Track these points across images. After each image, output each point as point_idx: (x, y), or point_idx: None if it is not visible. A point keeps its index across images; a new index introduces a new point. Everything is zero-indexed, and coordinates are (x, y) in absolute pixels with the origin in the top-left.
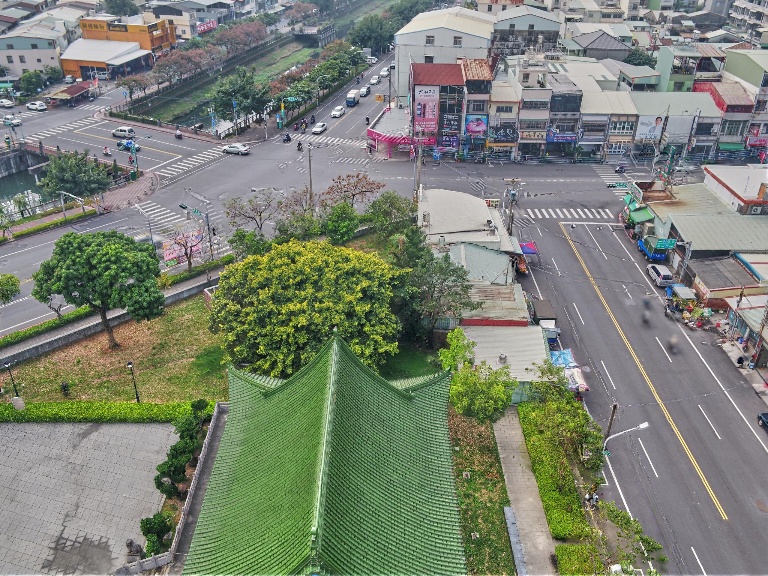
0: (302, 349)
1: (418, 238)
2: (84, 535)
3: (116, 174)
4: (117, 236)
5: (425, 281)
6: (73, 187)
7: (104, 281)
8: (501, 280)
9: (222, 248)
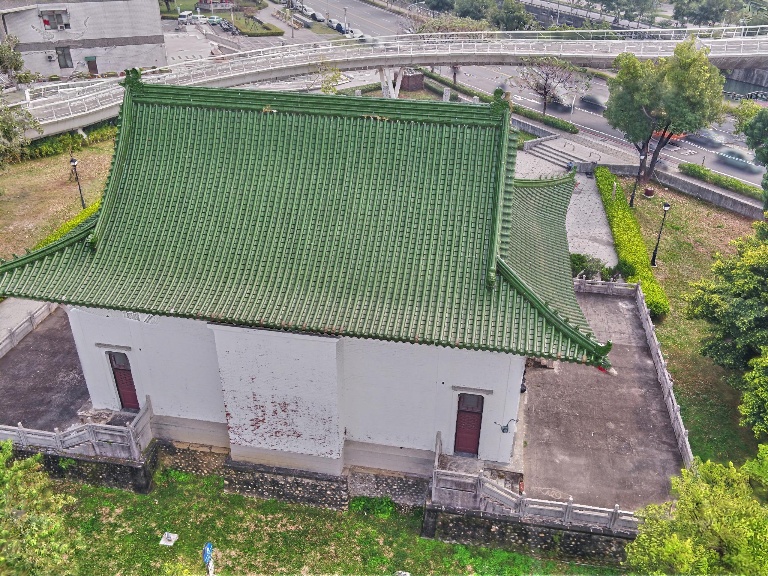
0: None
1: None
2: None
3: None
4: None
5: None
6: None
7: None
8: None
9: None
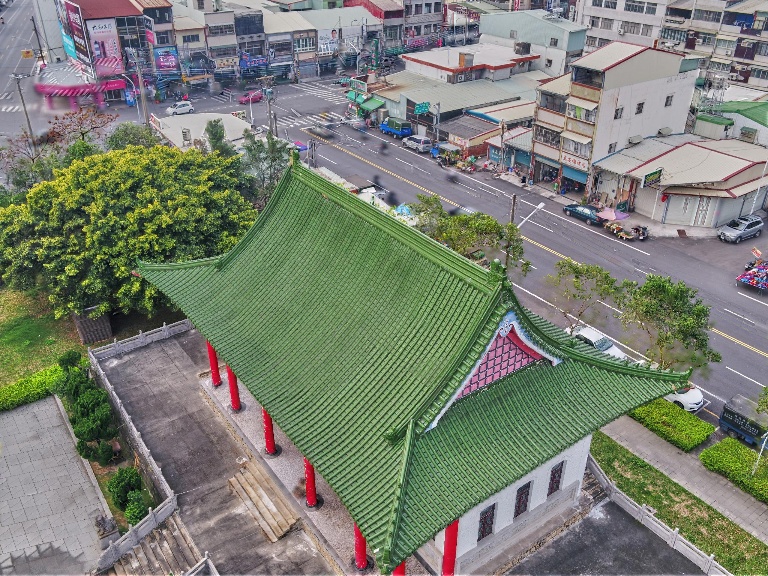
0: (171, 257)
1: None
2: (8, 556)
3: None
4: None
5: (256, 166)
6: None
7: None
8: None
9: None
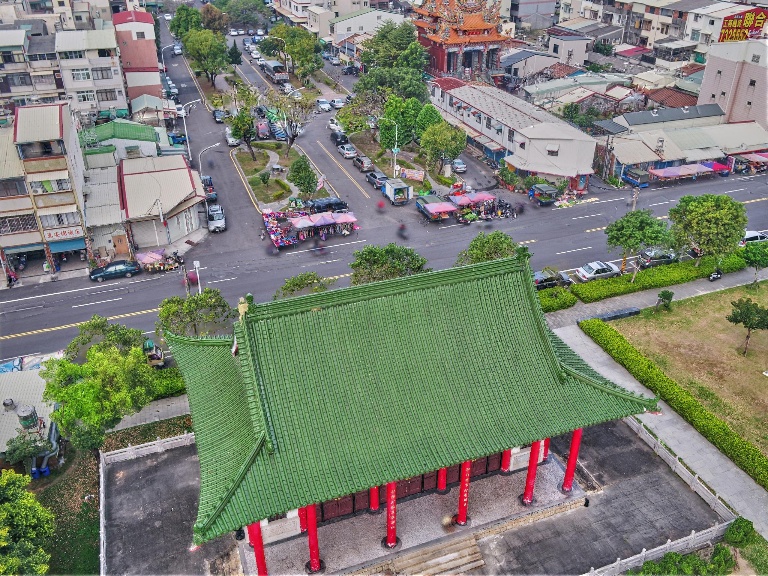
0: None
1: None
2: None
3: None
4: None
5: None
6: None
7: None
8: None
9: None
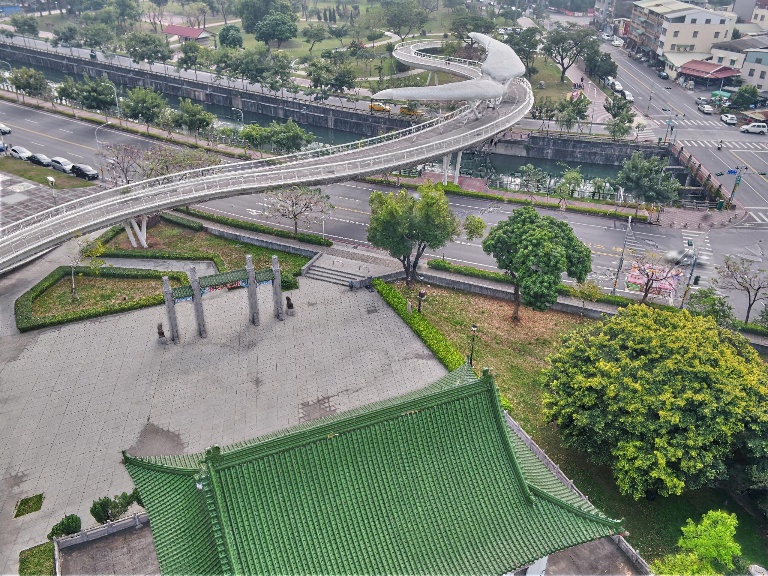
0: None
1: None
2: (337, 408)
3: (703, 196)
4: (562, 228)
5: None
6: (633, 187)
7: (520, 256)
8: None
9: None
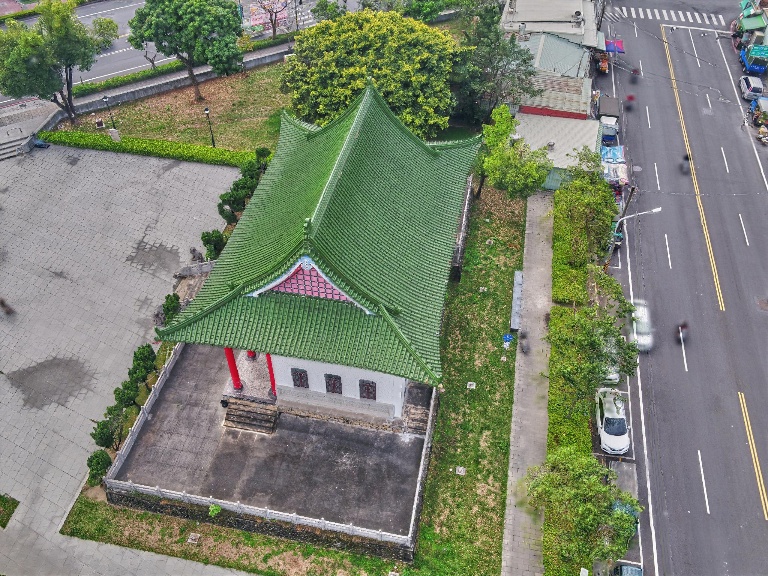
0: None
1: (491, 18)
2: (160, 242)
3: None
4: None
5: (488, 61)
6: None
7: (189, 32)
8: (573, 74)
9: (308, 20)
